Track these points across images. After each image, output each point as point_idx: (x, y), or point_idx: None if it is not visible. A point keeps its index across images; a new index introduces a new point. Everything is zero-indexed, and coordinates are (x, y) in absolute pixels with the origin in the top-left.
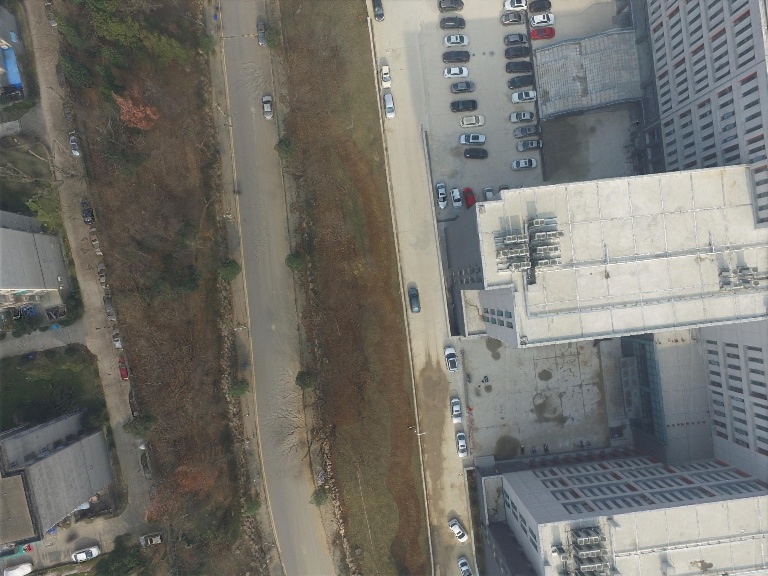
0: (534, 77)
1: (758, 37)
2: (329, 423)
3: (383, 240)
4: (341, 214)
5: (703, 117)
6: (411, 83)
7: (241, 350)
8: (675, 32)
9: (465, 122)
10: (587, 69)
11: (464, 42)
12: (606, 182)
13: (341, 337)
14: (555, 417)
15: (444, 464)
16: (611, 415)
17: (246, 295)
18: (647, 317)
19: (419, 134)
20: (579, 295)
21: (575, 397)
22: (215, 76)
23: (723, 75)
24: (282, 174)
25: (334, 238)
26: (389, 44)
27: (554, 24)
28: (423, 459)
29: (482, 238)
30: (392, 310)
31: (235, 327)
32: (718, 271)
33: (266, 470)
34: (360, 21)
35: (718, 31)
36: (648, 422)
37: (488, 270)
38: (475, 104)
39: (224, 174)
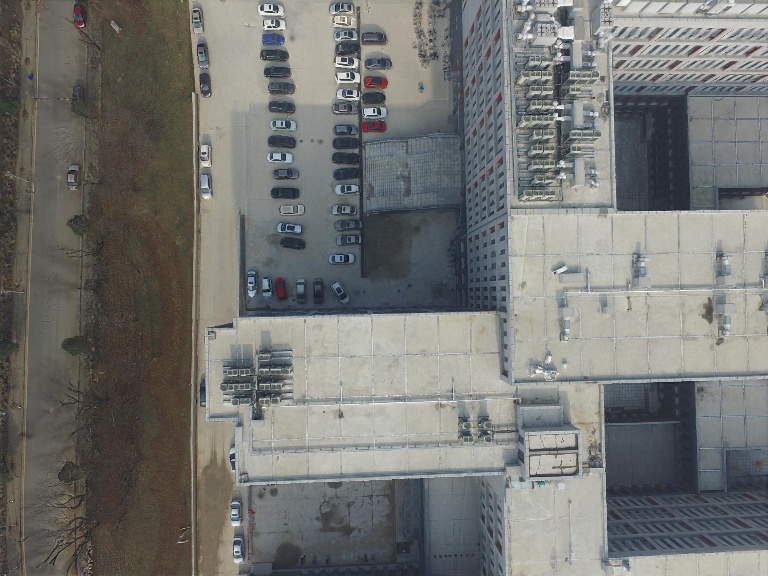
0: (359, 171)
1: (505, 187)
2: (93, 519)
3: (178, 328)
4: (132, 298)
5: (485, 246)
6: (233, 164)
7: (13, 431)
8: (476, 151)
9: (282, 211)
10: (411, 169)
11: (290, 128)
12: (348, 317)
13: (116, 429)
14: (341, 527)
15: (219, 568)
16: (399, 530)
17: (26, 373)
18: (379, 462)
19: (236, 217)
20: (309, 433)
21: (364, 508)
22: (23, 138)
23: (492, 212)
24: (81, 248)
25: (121, 323)
26: (211, 123)
27: (387, 118)
28: (197, 561)
29: (210, 365)
30: (177, 403)
31: (9, 407)
32: (458, 419)
33: (27, 561)
34: (185, 95)
35: (490, 167)
36: (423, 547)
37: (213, 400)
38: (295, 193)
39: (19, 243)
